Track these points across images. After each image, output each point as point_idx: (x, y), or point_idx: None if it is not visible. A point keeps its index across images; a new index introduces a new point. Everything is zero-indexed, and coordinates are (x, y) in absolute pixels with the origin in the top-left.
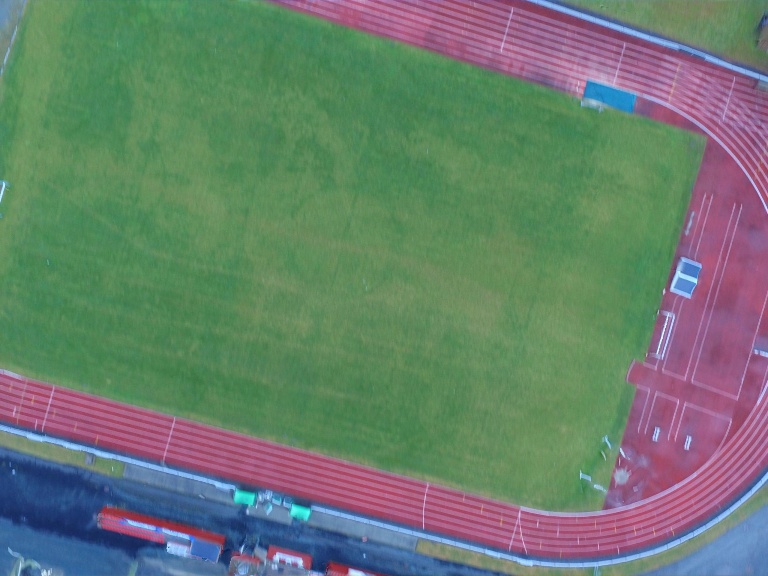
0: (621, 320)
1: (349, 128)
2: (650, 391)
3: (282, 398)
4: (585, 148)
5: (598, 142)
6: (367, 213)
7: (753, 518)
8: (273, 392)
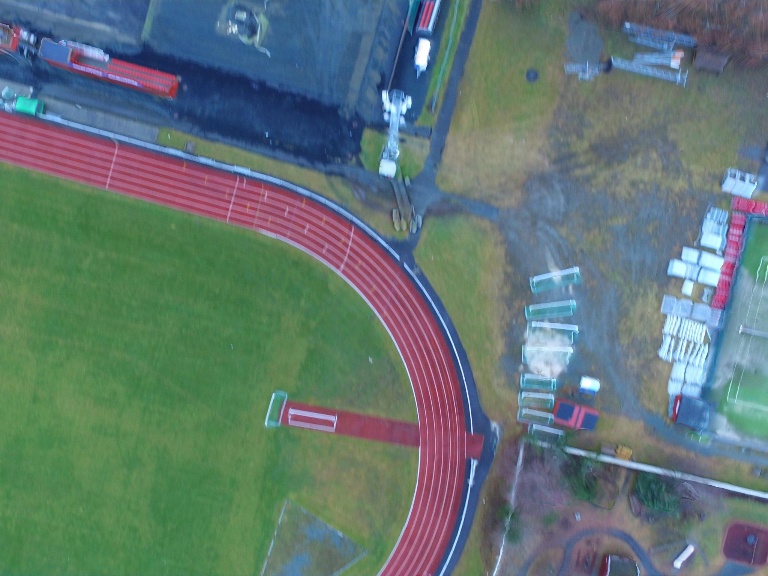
0: None
1: None
2: None
3: None
4: None
5: None
6: None
7: None
8: (7, 215)
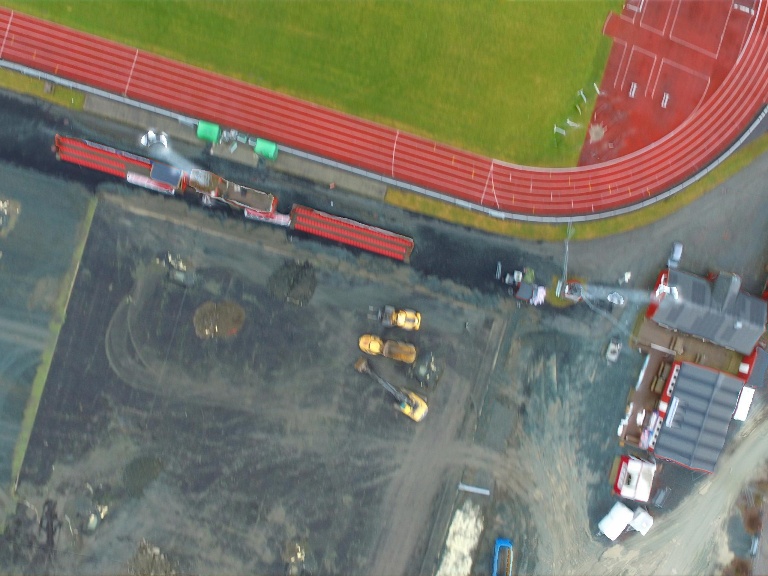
0: None
1: None
2: (627, 45)
3: (248, 34)
4: None
5: None
6: None
7: (731, 181)
8: (239, 27)
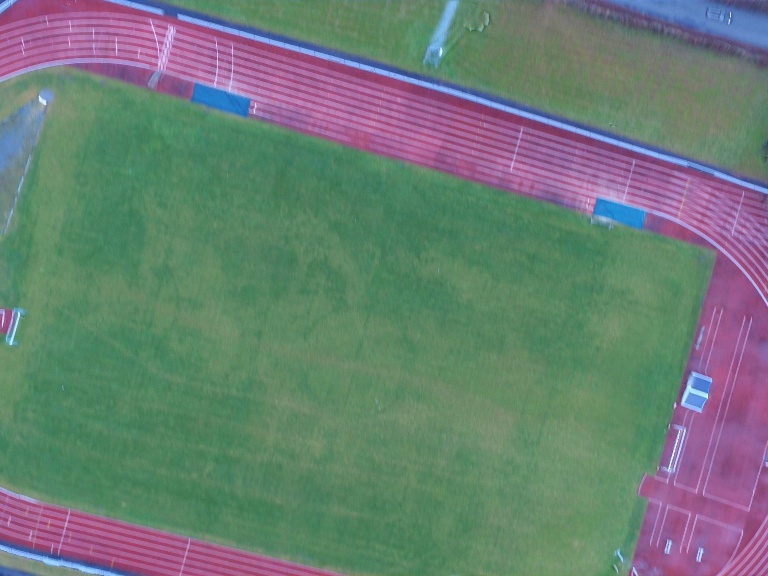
0: (632, 435)
1: (361, 250)
2: (662, 504)
3: (296, 518)
4: (595, 265)
5: (608, 259)
6: (379, 333)
7: None
8: (287, 512)
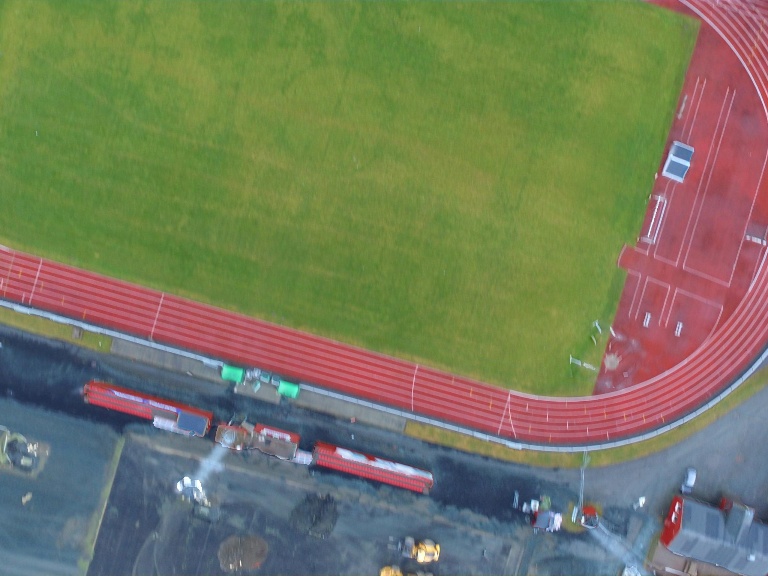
0: (613, 203)
1: (341, 4)
2: (641, 276)
3: (271, 276)
4: (578, 29)
5: (591, 23)
6: (358, 90)
7: (743, 406)
8: (262, 269)
